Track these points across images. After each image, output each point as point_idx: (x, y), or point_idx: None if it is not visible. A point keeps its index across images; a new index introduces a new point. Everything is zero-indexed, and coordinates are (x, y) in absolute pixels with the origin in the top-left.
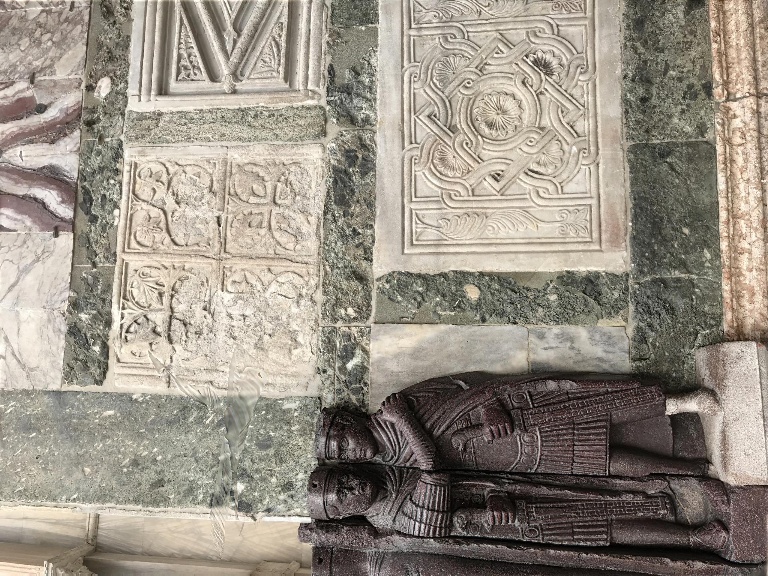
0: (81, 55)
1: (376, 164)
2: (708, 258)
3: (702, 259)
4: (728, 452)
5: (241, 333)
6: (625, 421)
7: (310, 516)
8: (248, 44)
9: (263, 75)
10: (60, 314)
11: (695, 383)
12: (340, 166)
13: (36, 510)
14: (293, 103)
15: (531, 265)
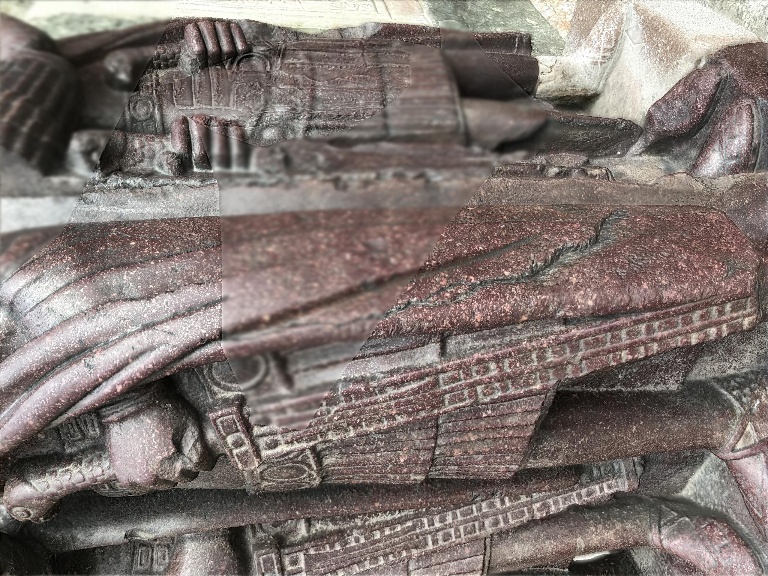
0: None
1: None
2: (534, 24)
3: (527, 24)
4: (669, 26)
5: None
6: None
7: None
8: None
9: None
10: None
11: (572, 101)
12: None
13: None
14: None
15: (292, 21)
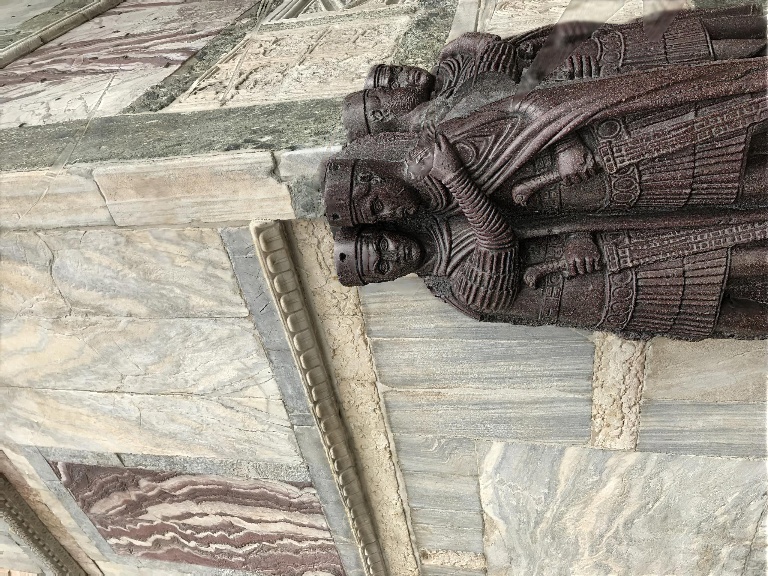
0: (235, 17)
1: (455, 15)
2: None
3: None
4: None
5: (307, 79)
6: (721, 27)
7: (344, 118)
8: (362, 1)
9: (370, 4)
10: (143, 90)
11: None
12: (423, 18)
13: (28, 173)
14: (390, 7)
15: None
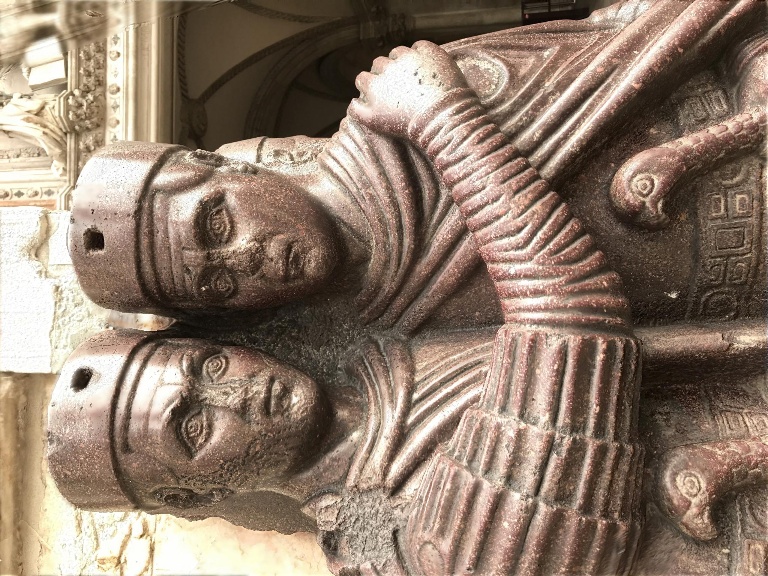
0: None
1: None
2: None
3: None
4: None
5: None
6: None
7: None
8: None
9: None
10: None
11: None
12: None
13: None
14: None
15: None
